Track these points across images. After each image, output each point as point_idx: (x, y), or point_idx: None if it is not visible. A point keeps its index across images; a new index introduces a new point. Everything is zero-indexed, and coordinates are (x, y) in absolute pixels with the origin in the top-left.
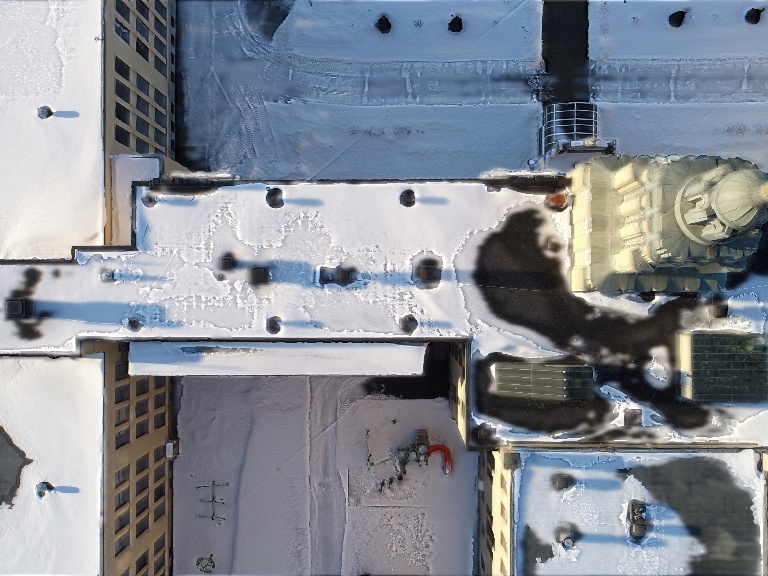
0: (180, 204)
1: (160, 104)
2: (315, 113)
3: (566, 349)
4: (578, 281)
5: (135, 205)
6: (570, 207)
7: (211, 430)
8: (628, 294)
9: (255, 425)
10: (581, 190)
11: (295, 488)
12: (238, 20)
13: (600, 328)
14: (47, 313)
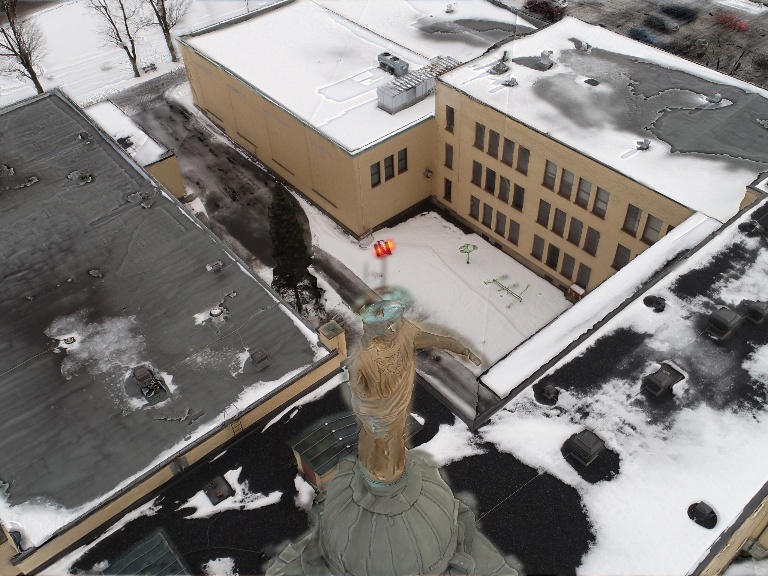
0: None
1: None
2: None
3: None
4: None
5: None
6: None
7: None
8: None
9: None
10: None
11: None
12: None
13: None
14: None
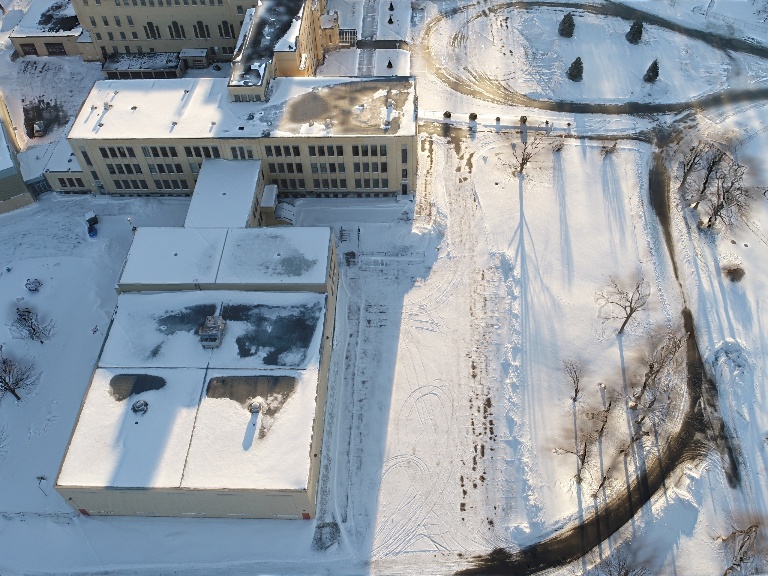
0: None
1: None
2: None
3: None
4: None
5: None
6: None
7: None
8: None
9: None
10: None
11: None
12: None
13: None
14: None
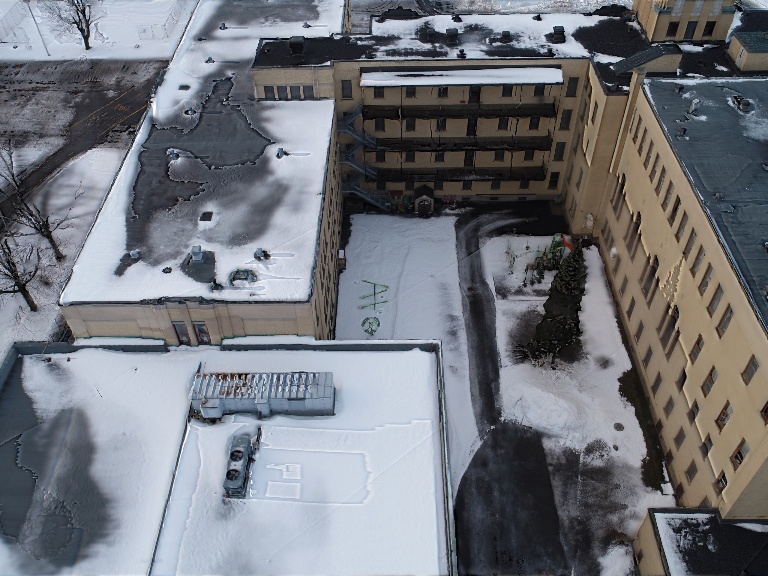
0: (399, 21)
1: None
2: None
3: None
4: None
5: (372, 22)
6: (636, 20)
7: (374, 254)
8: None
9: (412, 249)
10: None
11: (448, 290)
12: None
13: None
14: (312, 55)
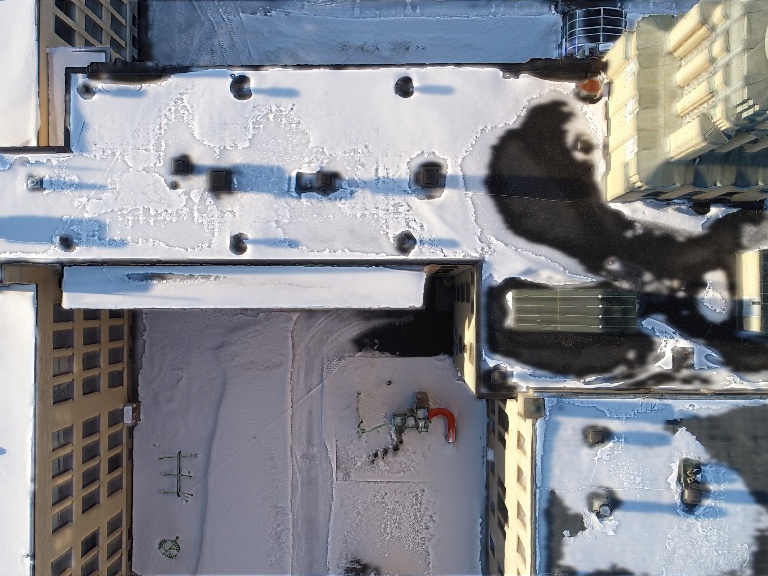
0: (124, 95)
1: (118, 11)
2: (299, 26)
3: (600, 274)
4: (617, 183)
5: (69, 96)
6: (605, 98)
7: (177, 392)
8: (677, 205)
9: (228, 386)
10: (621, 69)
11: (274, 460)
12: None
13: (642, 247)
14: None
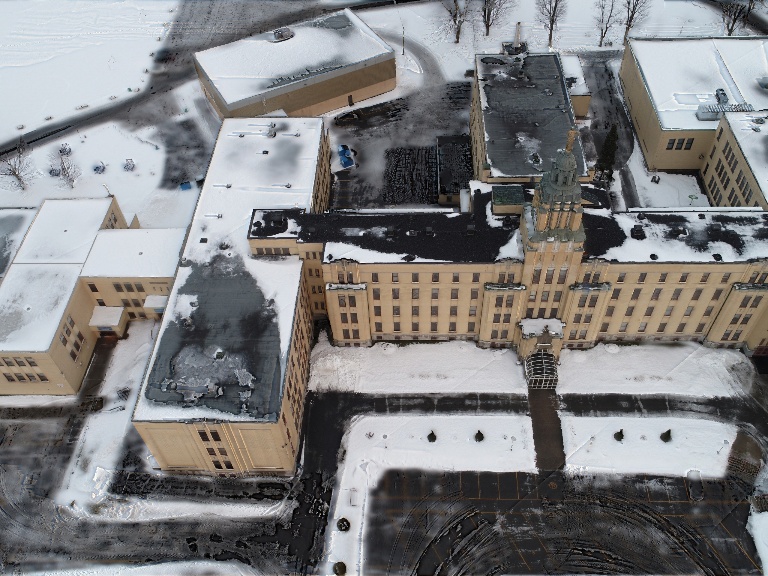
0: (764, 255)
1: None
2: (697, 389)
3: None
4: None
5: None
6: None
7: None
8: None
9: None
10: None
11: None
12: (765, 445)
13: None
14: None
